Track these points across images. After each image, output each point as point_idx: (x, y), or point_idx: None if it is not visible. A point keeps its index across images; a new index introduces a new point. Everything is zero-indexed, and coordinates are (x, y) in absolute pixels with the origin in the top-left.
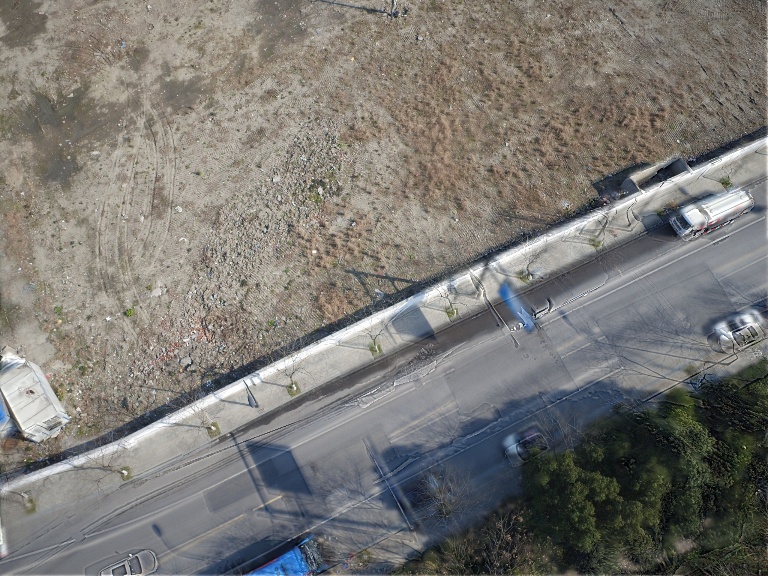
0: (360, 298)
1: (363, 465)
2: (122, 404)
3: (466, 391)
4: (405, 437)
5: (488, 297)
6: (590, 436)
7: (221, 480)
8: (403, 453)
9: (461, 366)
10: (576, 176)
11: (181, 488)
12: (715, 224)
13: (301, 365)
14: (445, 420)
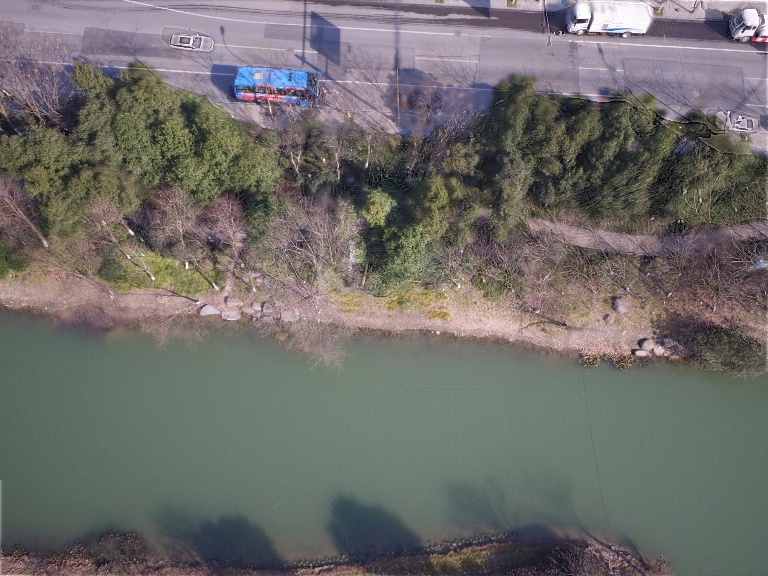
0: None
1: (387, 62)
2: None
3: (491, 54)
4: (428, 60)
5: (546, 3)
6: None
7: (282, 23)
8: (420, 68)
9: (497, 37)
10: None
11: (252, 14)
12: (766, 31)
13: None
14: (464, 64)
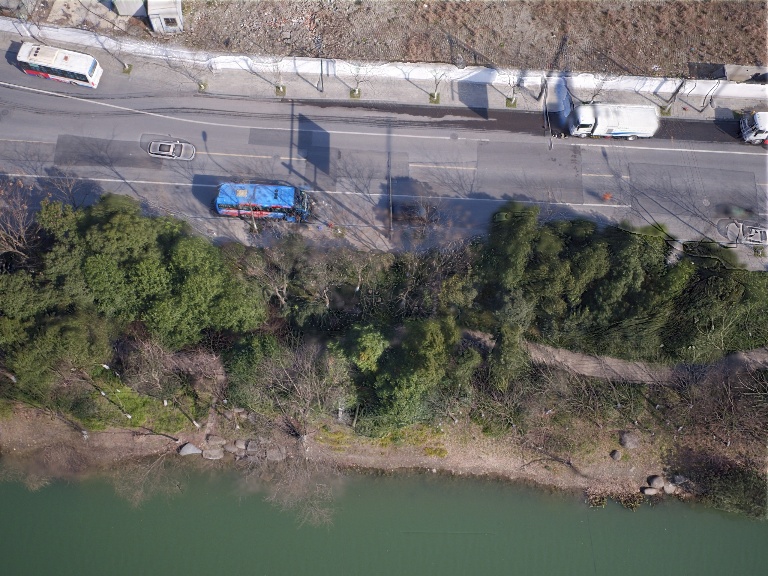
0: (443, 54)
1: (379, 170)
2: (225, 41)
3: (490, 160)
4: (423, 167)
5: (547, 103)
6: (570, 219)
7: (268, 127)
8: (415, 177)
9: (496, 141)
10: (677, 49)
11: (237, 117)
12: None
13: (370, 79)
14: (461, 171)
